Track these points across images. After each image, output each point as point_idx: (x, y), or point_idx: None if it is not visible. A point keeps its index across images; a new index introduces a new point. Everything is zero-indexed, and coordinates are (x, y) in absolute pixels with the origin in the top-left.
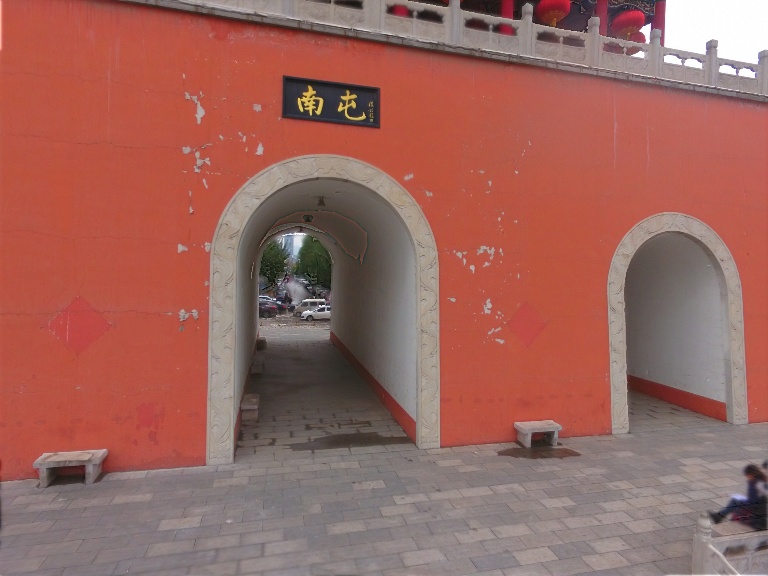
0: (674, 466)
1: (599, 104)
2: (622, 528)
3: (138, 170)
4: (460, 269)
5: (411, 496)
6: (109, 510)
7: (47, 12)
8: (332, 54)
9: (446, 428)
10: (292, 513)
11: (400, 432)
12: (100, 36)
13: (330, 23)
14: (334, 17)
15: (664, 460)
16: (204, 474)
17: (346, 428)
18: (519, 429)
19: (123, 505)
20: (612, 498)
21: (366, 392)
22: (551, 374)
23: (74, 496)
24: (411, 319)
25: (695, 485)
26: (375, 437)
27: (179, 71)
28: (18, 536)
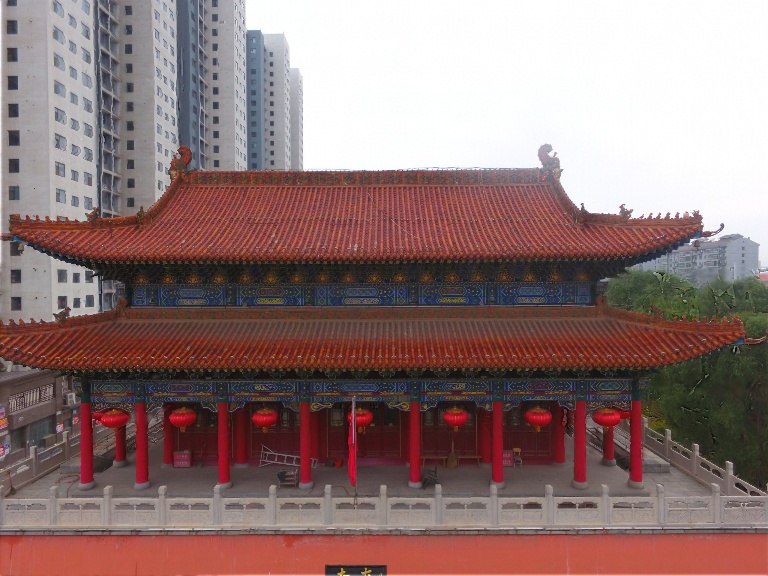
0: None
1: (554, 554)
2: None
3: None
4: None
5: None
6: None
7: (200, 546)
8: (355, 546)
9: None
10: None
11: None
12: (226, 555)
13: (354, 523)
14: (357, 518)
15: None
16: None
17: None
18: None
19: None
20: None
21: None
22: None
23: None
24: None
25: None
26: None
27: (267, 570)
28: None
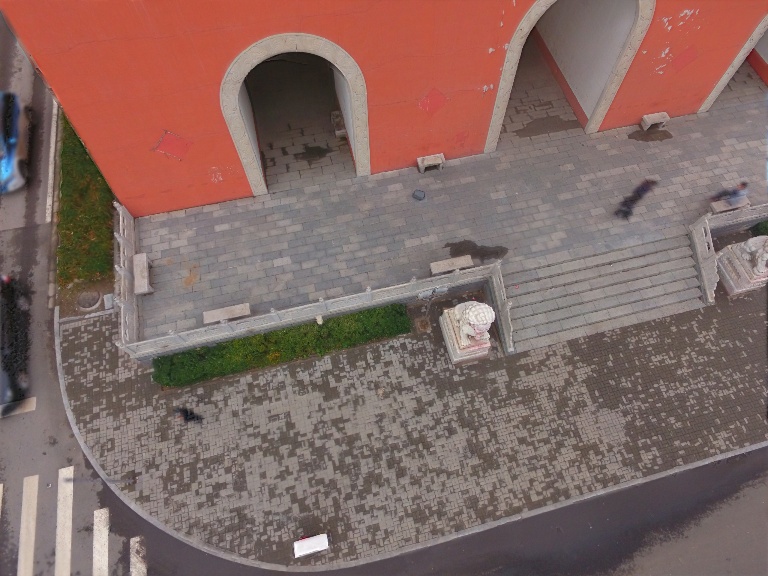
0: (719, 147)
1: None
2: (677, 194)
3: (474, 2)
4: (661, 31)
5: (588, 175)
6: (464, 188)
7: None
8: None
9: (605, 123)
10: (540, 188)
11: (572, 115)
12: None
13: None
14: None
15: (716, 141)
16: (487, 161)
17: (540, 111)
18: (645, 121)
19: (468, 184)
20: (678, 175)
21: (538, 55)
22: (681, 86)
23: (442, 179)
24: (609, 59)
25: (721, 164)
26: (559, 121)
27: None
28: (443, 204)
